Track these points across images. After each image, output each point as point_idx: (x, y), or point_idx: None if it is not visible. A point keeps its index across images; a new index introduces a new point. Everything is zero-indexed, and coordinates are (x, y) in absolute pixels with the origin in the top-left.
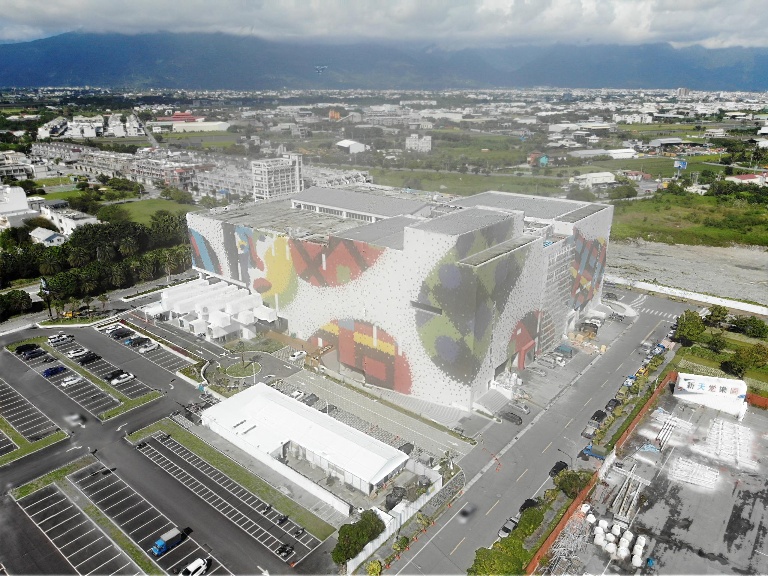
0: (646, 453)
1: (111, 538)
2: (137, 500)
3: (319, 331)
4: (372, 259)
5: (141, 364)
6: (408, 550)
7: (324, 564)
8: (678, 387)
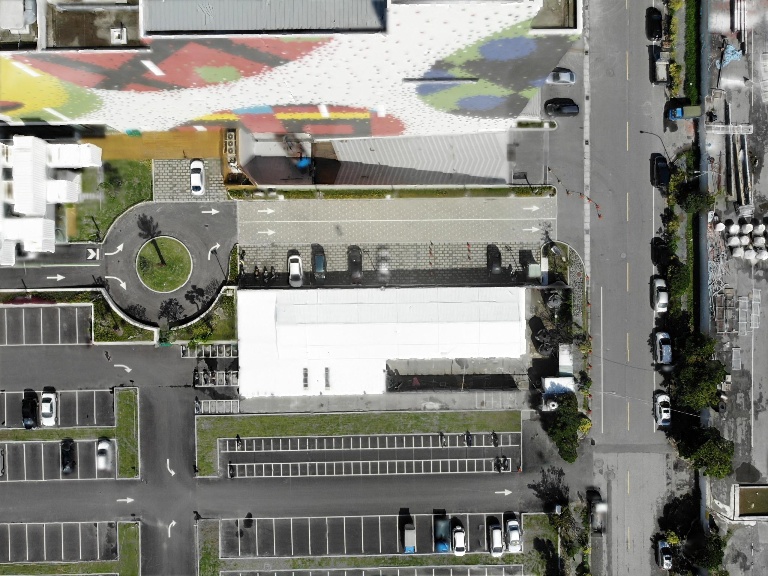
0: (729, 68)
1: (355, 568)
2: (322, 524)
3: (191, 122)
4: (295, 53)
5: (17, 362)
6: (592, 383)
7: (542, 450)
8: None
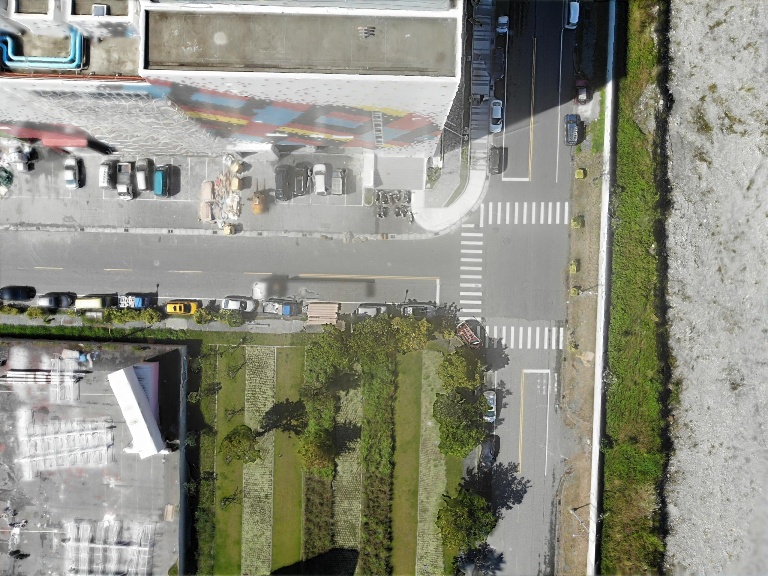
0: None
1: None
2: None
3: None
4: None
5: None
6: None
7: None
8: None
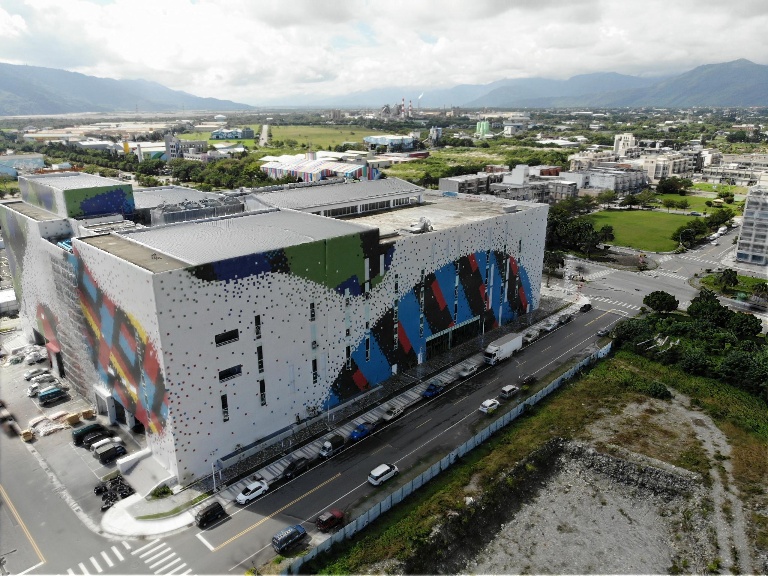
0: None
1: None
2: None
3: None
4: None
5: None
6: None
7: None
8: None
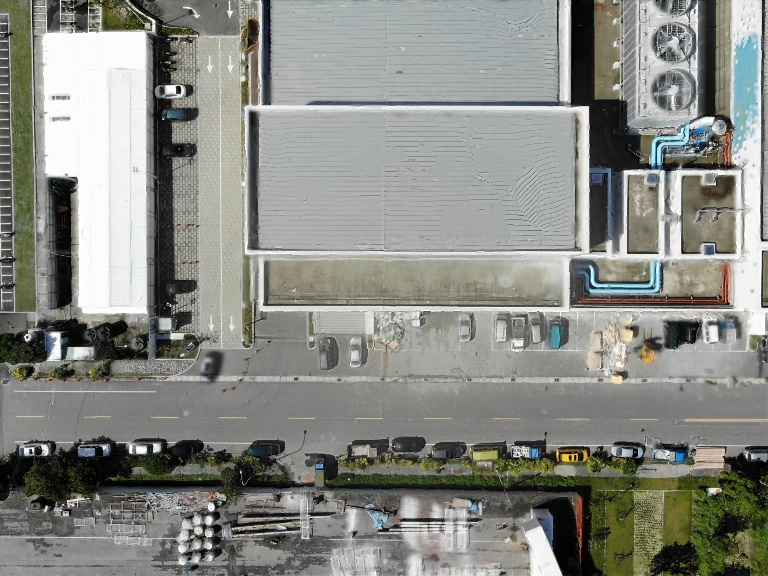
0: (366, 517)
1: None
2: None
3: None
4: None
5: None
6: (63, 382)
7: None
8: (522, 525)
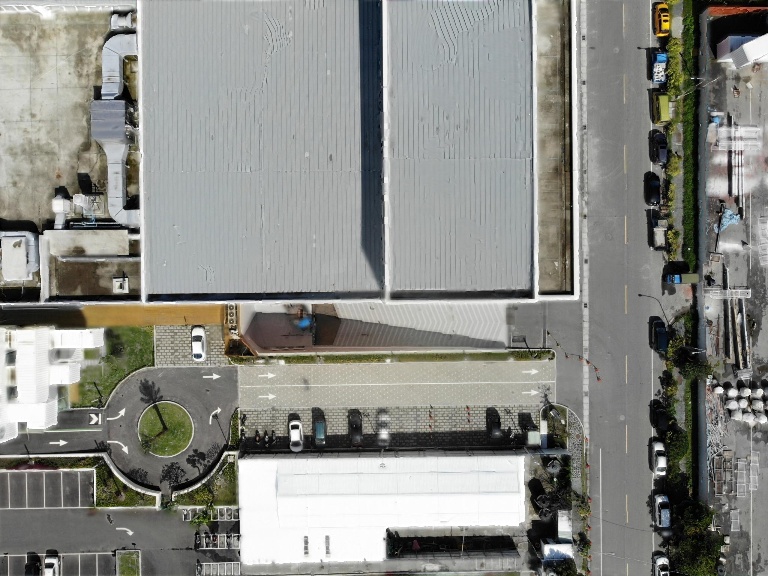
0: (727, 232)
1: None
2: None
3: None
4: None
5: (20, 525)
6: (592, 544)
7: None
8: None
